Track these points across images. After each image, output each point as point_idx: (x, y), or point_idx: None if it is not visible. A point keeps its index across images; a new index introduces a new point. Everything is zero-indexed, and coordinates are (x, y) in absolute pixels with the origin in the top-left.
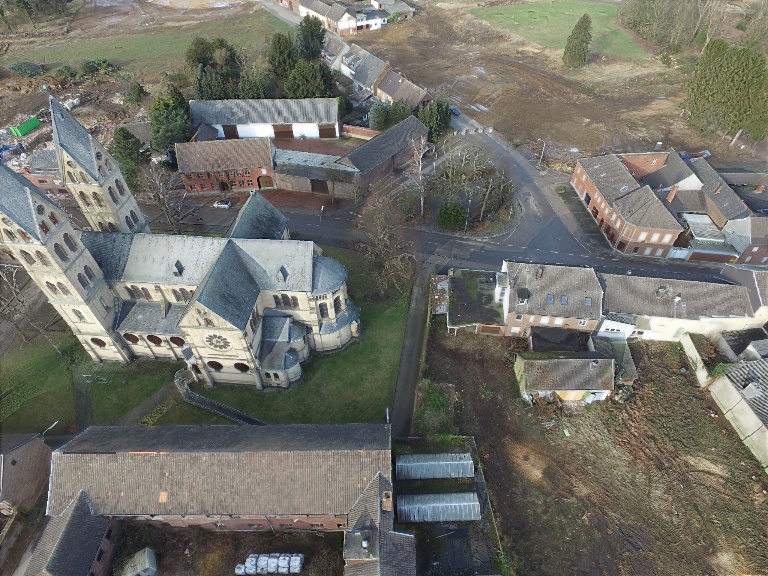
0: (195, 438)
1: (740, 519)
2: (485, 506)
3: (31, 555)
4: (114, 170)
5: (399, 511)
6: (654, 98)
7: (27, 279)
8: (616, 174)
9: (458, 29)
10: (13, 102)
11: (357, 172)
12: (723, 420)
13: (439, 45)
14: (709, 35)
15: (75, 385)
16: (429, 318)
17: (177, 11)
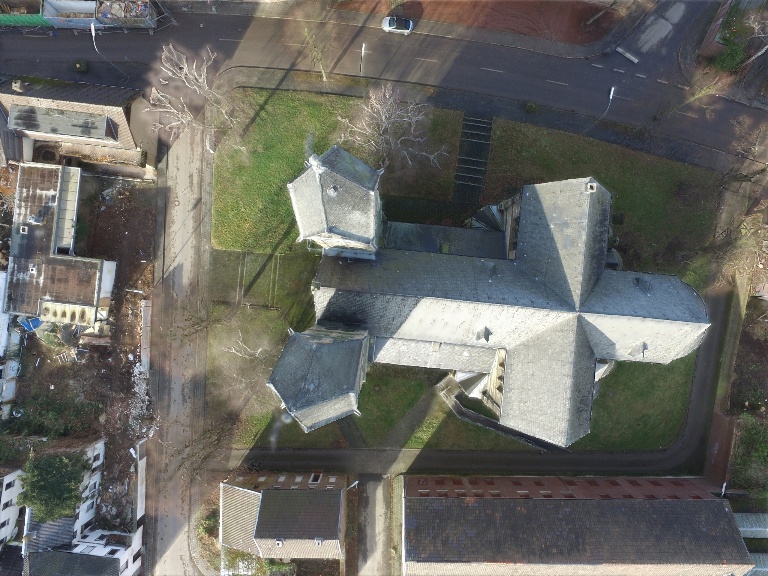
0: (533, 529)
1: None
2: None
3: (366, 564)
4: (375, 191)
5: None
6: None
7: (161, 205)
8: None
9: None
10: None
11: None
12: None
13: None
14: None
15: None
16: None
17: None
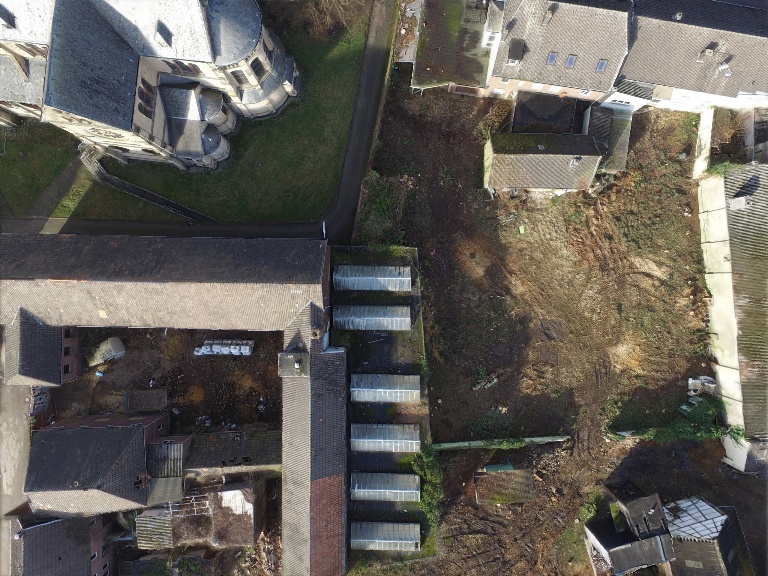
0: (116, 257)
1: (655, 318)
2: (417, 318)
3: None
4: None
5: (335, 322)
6: None
7: None
8: None
9: None
10: None
11: None
12: (694, 220)
13: None
14: None
15: None
16: (389, 70)
17: None
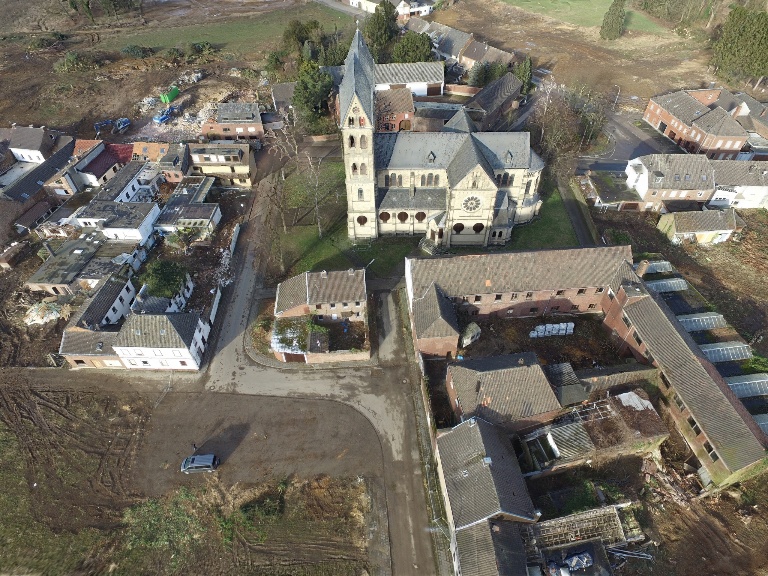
0: (490, 253)
1: None
2: None
3: (384, 339)
4: None
5: None
6: (682, 60)
7: (253, 197)
8: (688, 104)
9: (497, 13)
10: (141, 78)
11: (485, 112)
12: None
13: (487, 26)
14: (714, 11)
15: (345, 253)
16: (585, 201)
17: (235, 4)
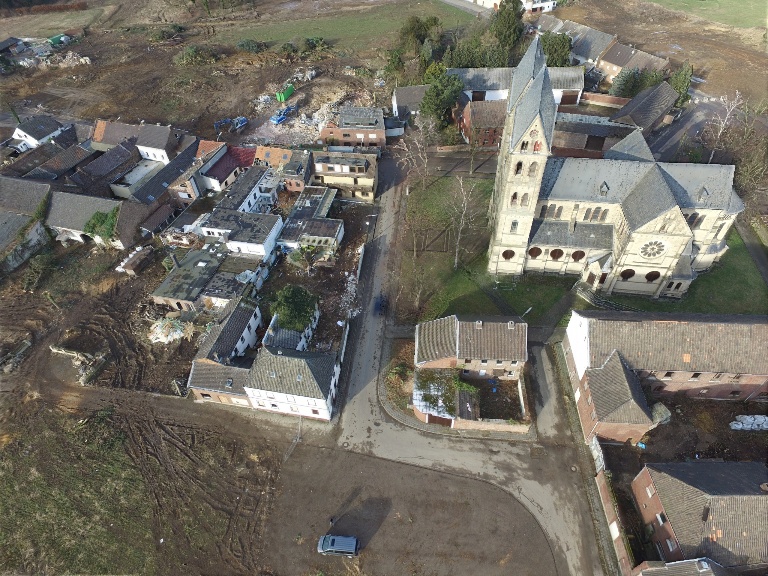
0: None
1: None
2: None
3: (543, 408)
4: None
5: None
6: None
7: (375, 212)
8: None
9: (631, 11)
10: (256, 74)
11: None
12: None
13: (620, 25)
14: None
15: (485, 291)
16: None
17: None
